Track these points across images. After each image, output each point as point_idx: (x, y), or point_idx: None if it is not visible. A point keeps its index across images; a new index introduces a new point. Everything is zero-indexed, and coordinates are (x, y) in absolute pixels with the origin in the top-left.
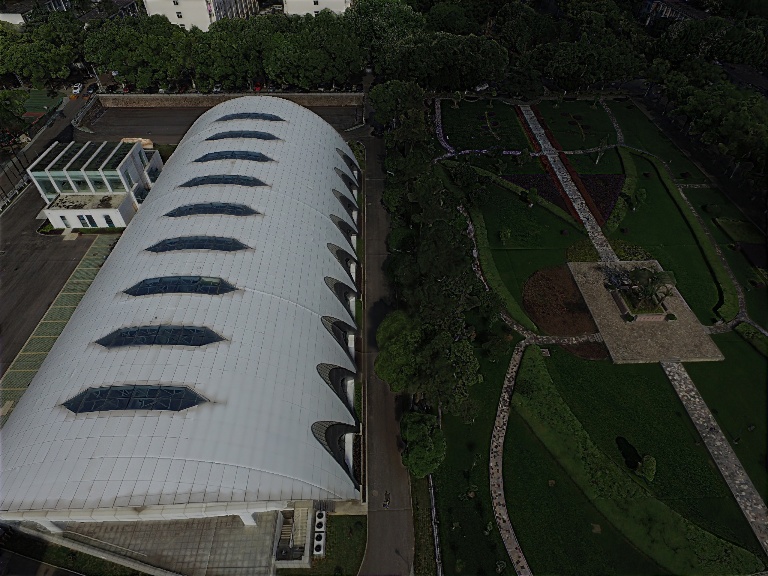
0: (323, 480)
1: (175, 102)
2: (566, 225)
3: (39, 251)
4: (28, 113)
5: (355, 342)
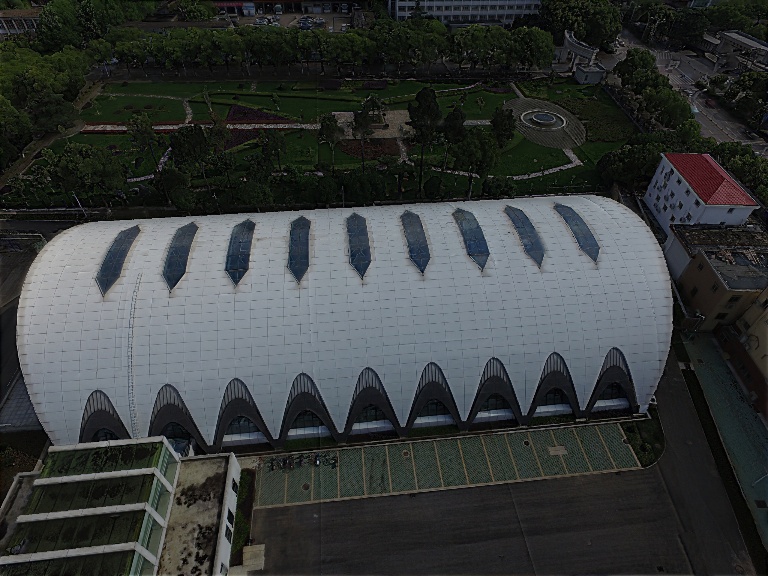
0: None
1: None
2: (291, 135)
3: None
4: None
5: None
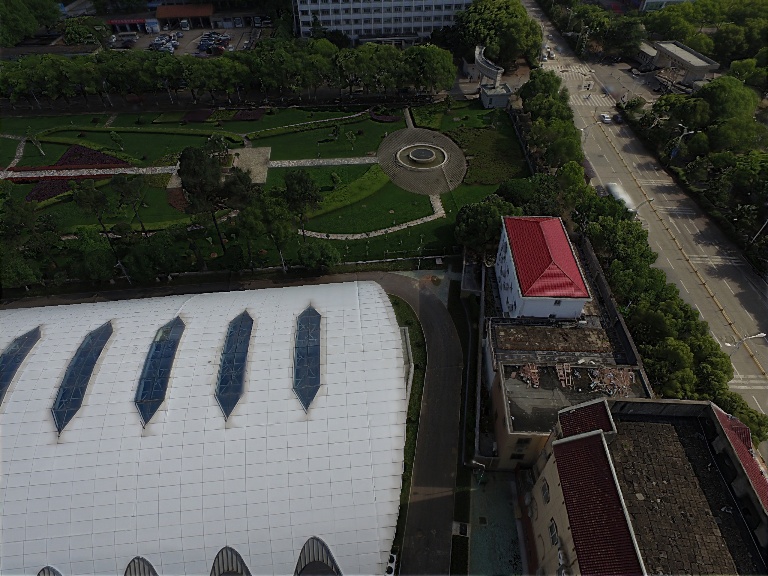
0: None
1: None
2: None
3: None
4: None
5: None
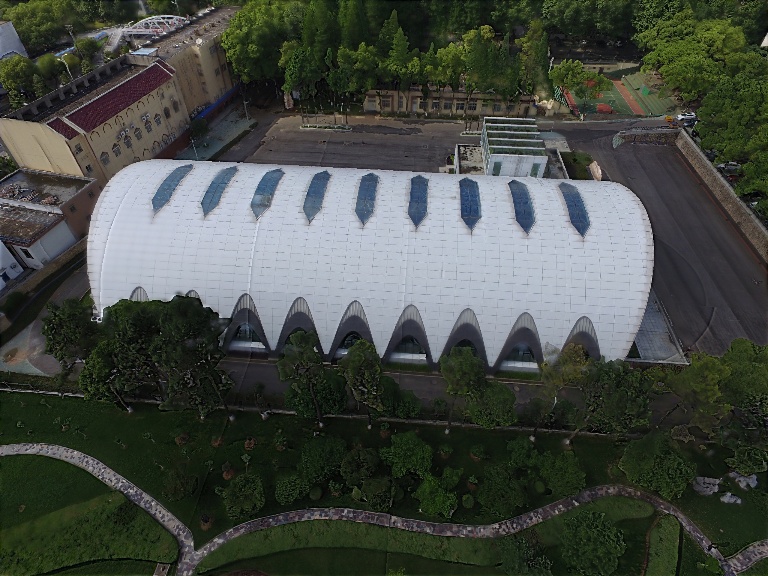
0: (106, 300)
1: (713, 182)
2: None
3: (426, 160)
4: (640, 110)
5: (262, 352)
